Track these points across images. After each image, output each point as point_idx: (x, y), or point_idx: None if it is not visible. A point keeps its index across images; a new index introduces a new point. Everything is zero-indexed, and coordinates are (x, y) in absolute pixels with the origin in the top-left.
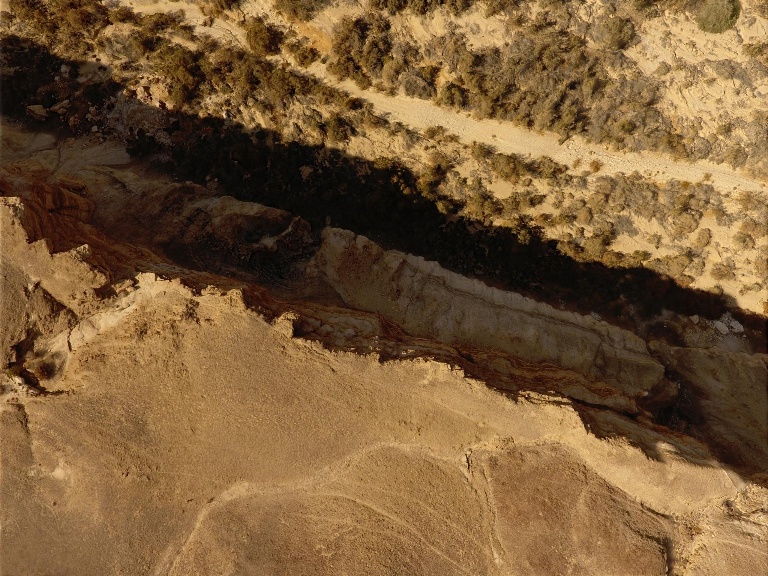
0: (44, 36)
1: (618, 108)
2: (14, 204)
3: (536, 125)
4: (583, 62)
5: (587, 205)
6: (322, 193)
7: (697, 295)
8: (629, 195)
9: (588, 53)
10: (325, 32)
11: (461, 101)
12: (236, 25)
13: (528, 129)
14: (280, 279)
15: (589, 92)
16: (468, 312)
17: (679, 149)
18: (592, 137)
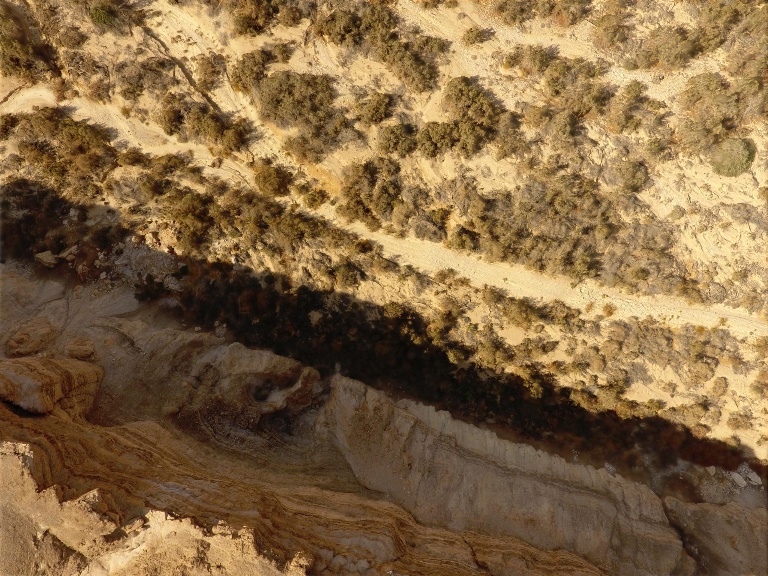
0: (53, 179)
1: (631, 253)
2: (23, 452)
3: (548, 269)
4: (596, 208)
5: (600, 352)
6: (331, 340)
7: (713, 446)
8: (643, 342)
9: (601, 196)
10: (334, 175)
11: (472, 246)
12: (245, 166)
13: (540, 272)
14: (289, 437)
15: (602, 237)
16: (481, 484)
17: (694, 296)
18: (605, 281)
